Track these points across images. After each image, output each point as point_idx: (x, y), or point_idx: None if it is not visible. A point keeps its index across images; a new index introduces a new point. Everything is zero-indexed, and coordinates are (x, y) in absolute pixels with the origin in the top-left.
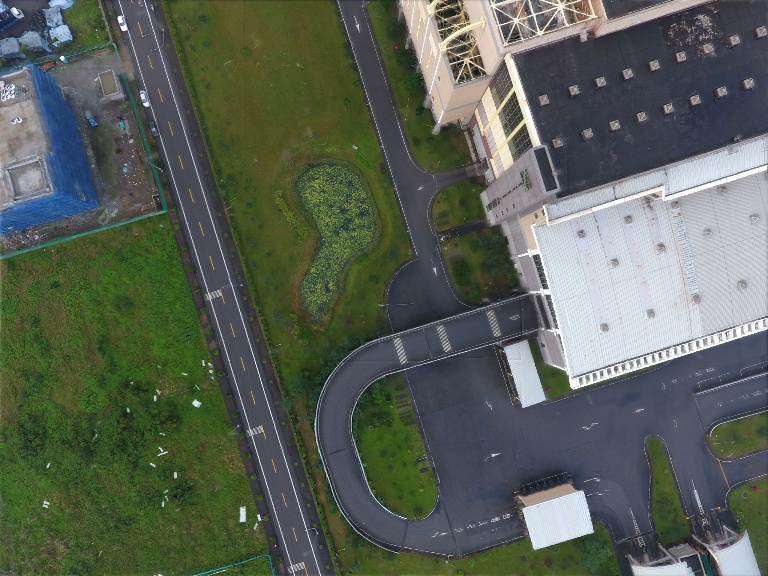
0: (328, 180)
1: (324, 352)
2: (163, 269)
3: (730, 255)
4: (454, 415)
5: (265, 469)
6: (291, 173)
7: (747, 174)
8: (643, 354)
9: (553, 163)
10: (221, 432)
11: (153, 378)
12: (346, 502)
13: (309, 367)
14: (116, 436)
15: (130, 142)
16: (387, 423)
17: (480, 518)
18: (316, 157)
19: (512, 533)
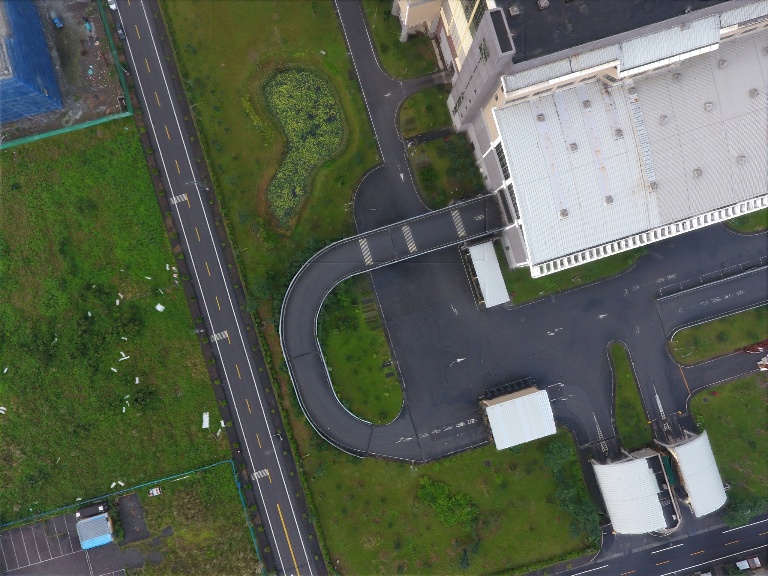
0: (296, 86)
1: (290, 255)
2: (127, 172)
3: (686, 143)
4: (420, 320)
5: (229, 375)
6: (259, 78)
7: (699, 52)
8: (602, 243)
9: (510, 31)
10: (185, 336)
11: (116, 281)
12: (311, 407)
13: (275, 271)
14: (76, 340)
15: (96, 44)
16: (352, 327)
17: (445, 423)
18: (284, 62)
19: (477, 438)
